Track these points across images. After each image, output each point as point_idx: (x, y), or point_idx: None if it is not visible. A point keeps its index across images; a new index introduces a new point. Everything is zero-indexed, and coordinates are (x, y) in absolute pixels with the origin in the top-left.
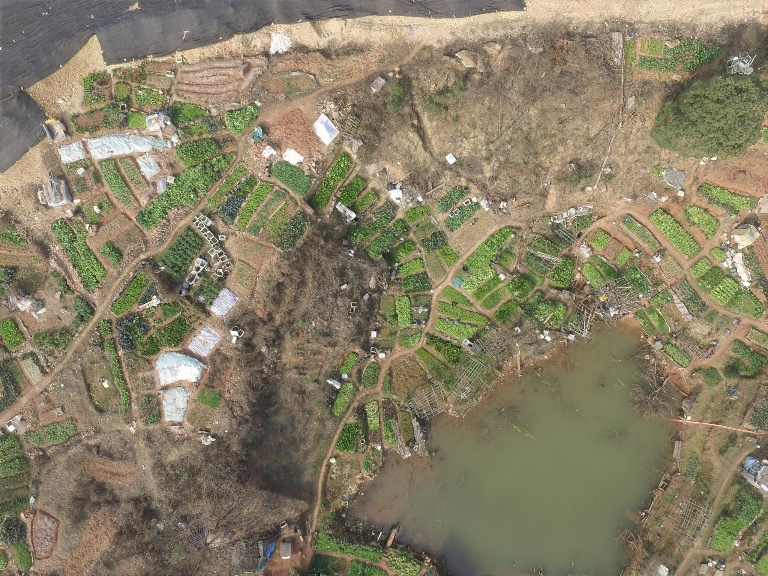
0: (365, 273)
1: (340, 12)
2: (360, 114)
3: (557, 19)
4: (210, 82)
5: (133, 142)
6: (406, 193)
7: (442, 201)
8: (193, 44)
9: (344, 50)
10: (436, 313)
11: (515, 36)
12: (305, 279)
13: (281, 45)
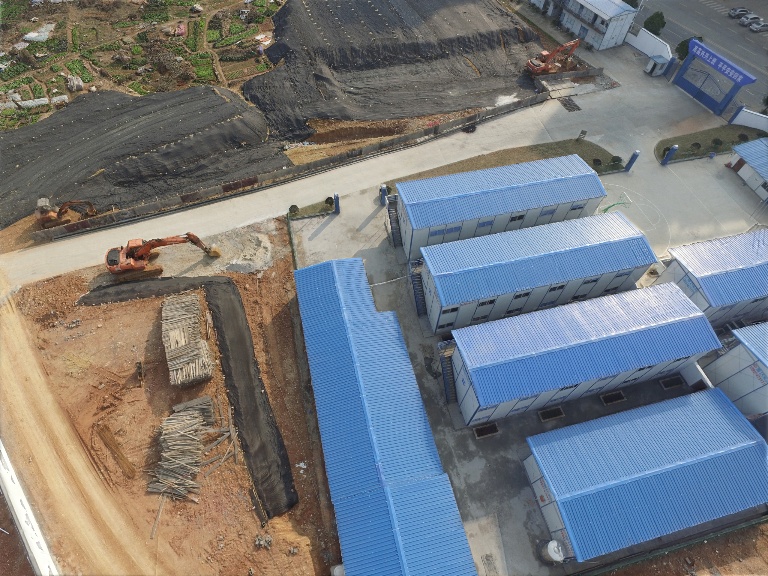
0: None
1: None
2: None
3: None
4: None
5: None
6: None
7: None
8: None
9: None
10: None
11: None
12: None
13: None
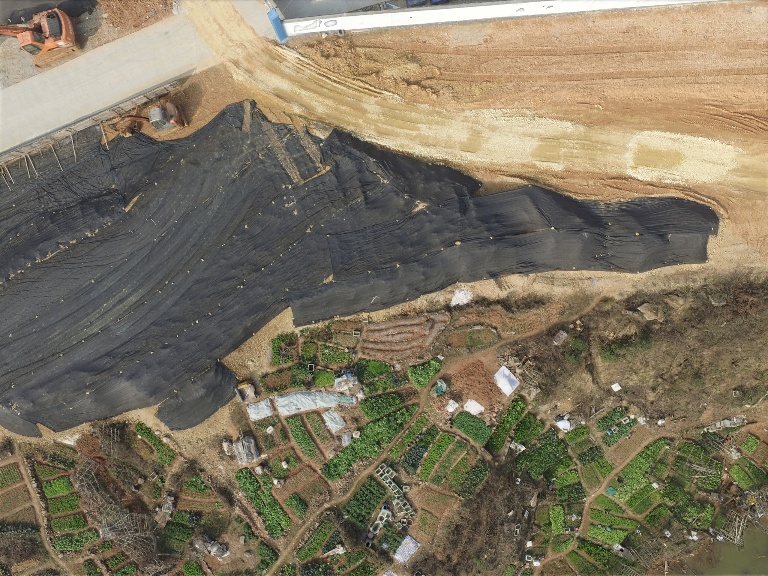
0: (527, 494)
1: (523, 269)
2: (541, 366)
3: (738, 269)
4: (395, 340)
5: (320, 400)
6: (573, 423)
7: (603, 422)
8: (381, 307)
9: (524, 302)
10: (588, 519)
11: (696, 288)
12: (480, 517)
13: (463, 299)
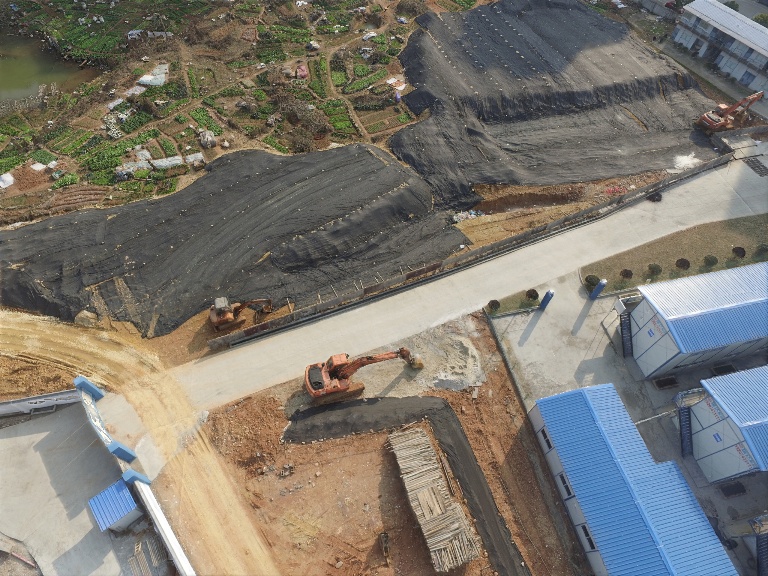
0: None
1: None
2: None
3: None
4: None
5: None
6: None
7: None
8: None
9: None
10: (4, 144)
11: None
12: None
13: None
